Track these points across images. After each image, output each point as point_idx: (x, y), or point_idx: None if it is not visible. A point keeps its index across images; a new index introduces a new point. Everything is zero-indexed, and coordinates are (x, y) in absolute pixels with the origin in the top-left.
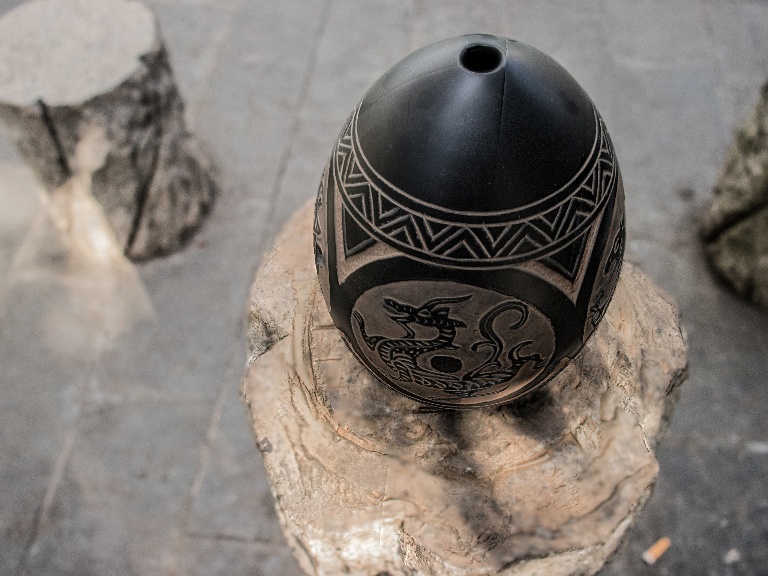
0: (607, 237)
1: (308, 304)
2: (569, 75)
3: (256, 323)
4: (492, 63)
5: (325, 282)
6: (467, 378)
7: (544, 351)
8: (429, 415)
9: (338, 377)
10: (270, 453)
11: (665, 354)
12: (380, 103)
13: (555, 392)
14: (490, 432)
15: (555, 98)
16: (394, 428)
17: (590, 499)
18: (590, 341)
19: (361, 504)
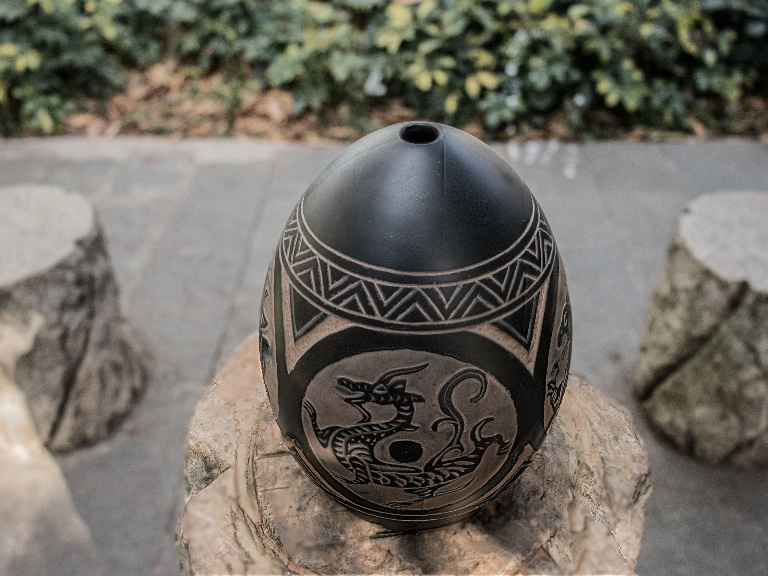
0: (556, 306)
1: (251, 434)
2: None
3: (195, 459)
4: (430, 138)
5: (272, 379)
6: (429, 468)
7: (506, 431)
8: (388, 539)
9: (286, 506)
10: None
11: (625, 460)
12: (325, 182)
13: (520, 505)
14: (456, 552)
15: (492, 168)
16: (351, 557)
17: None
18: (549, 451)
19: None
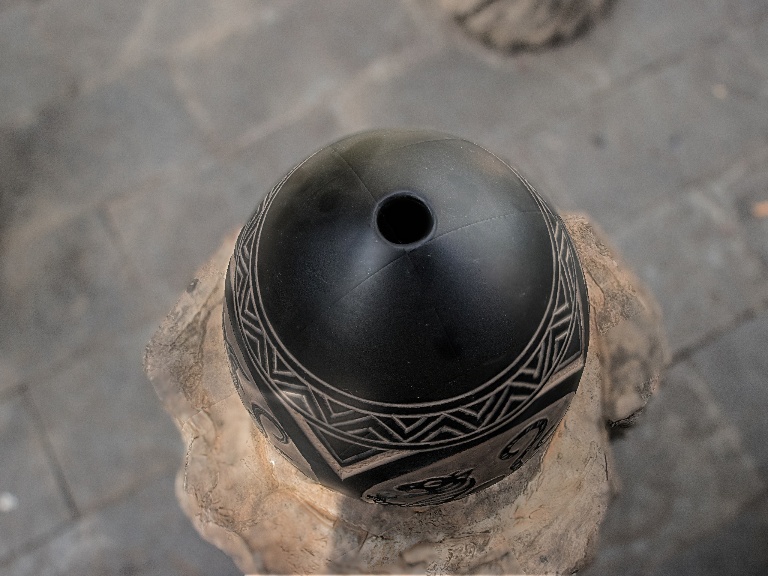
0: (413, 471)
1: None
2: (511, 317)
3: None
4: (412, 234)
5: None
6: None
7: None
8: None
9: None
10: (187, 293)
11: None
12: (330, 156)
13: None
14: None
15: (434, 326)
16: None
17: None
18: (476, 497)
19: (190, 394)
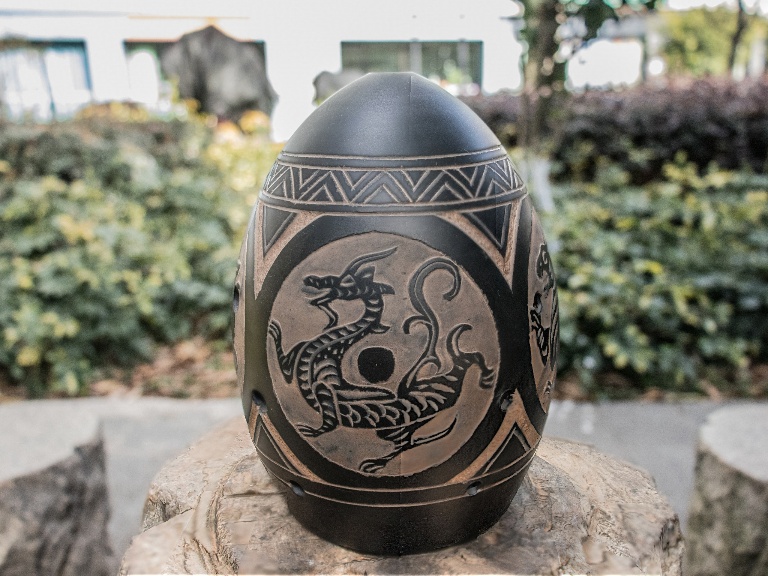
0: (531, 233)
1: (220, 483)
2: None
3: (153, 512)
4: None
5: (240, 324)
6: (403, 392)
7: (488, 353)
8: (365, 562)
9: (249, 535)
10: None
11: (647, 507)
12: None
13: (523, 534)
14: (447, 574)
15: None
16: None
17: None
18: (556, 494)
19: None
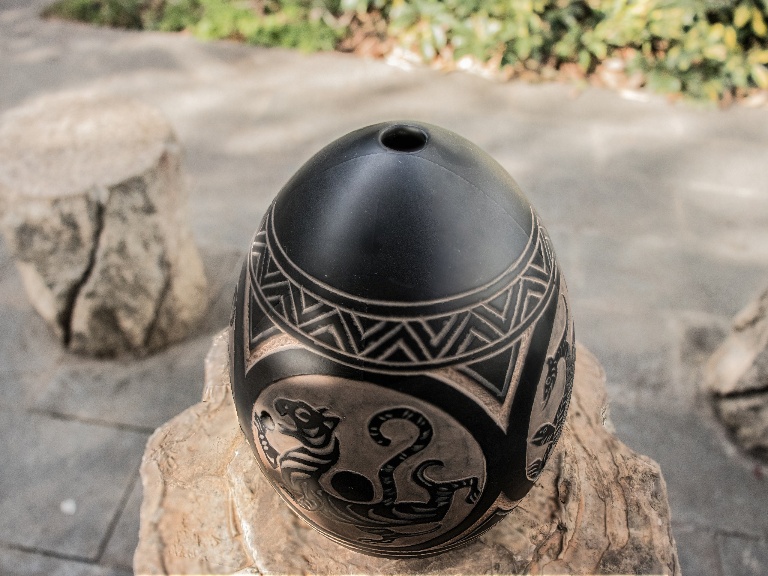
0: (292, 378)
1: None
2: (436, 258)
3: None
4: (403, 150)
5: None
6: None
7: None
8: None
9: None
10: None
11: None
12: None
13: (302, 549)
14: None
15: (370, 215)
16: None
17: (178, 569)
18: None
19: None
